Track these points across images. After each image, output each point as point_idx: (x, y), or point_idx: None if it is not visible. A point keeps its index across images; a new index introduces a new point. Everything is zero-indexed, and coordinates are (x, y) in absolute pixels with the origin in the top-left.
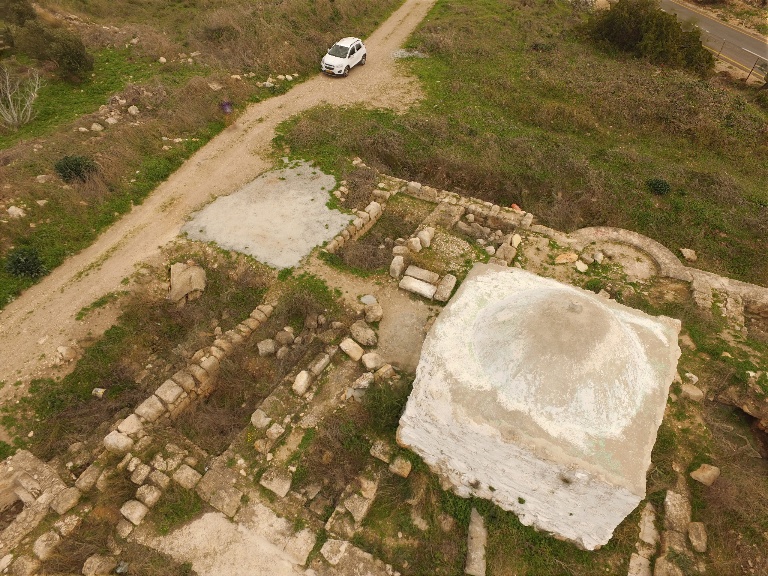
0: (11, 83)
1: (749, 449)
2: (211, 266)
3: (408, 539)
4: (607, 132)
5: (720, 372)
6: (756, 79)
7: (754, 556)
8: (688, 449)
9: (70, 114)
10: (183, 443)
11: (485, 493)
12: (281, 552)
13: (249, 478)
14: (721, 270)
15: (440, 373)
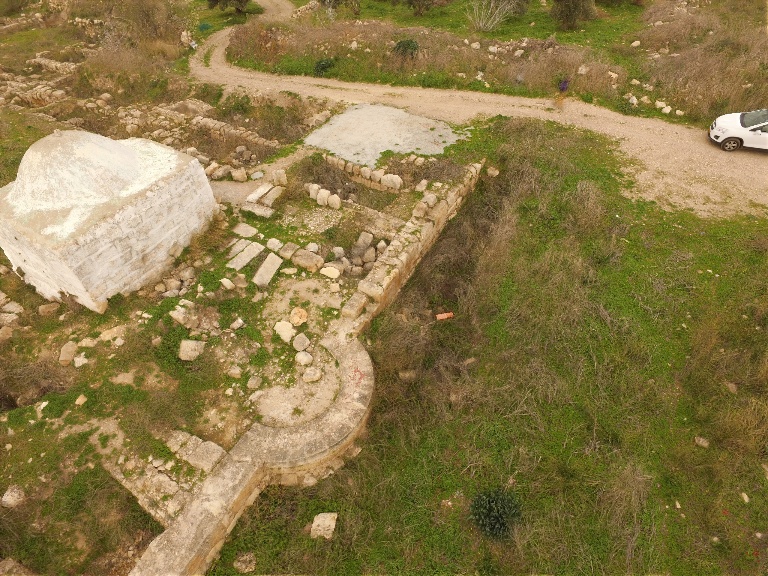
0: None
1: None
2: None
3: None
4: None
5: None
6: None
7: None
8: None
9: (506, 39)
10: (191, 140)
11: None
12: None
13: None
14: None
15: None
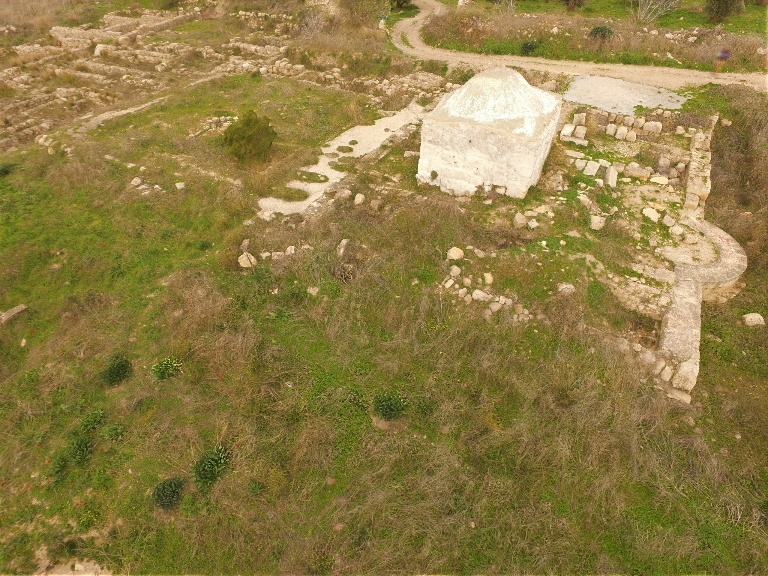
0: (667, 0)
1: None
2: None
3: None
4: None
5: None
6: None
7: None
8: None
9: None
10: None
11: None
12: None
13: None
14: (743, 344)
15: None
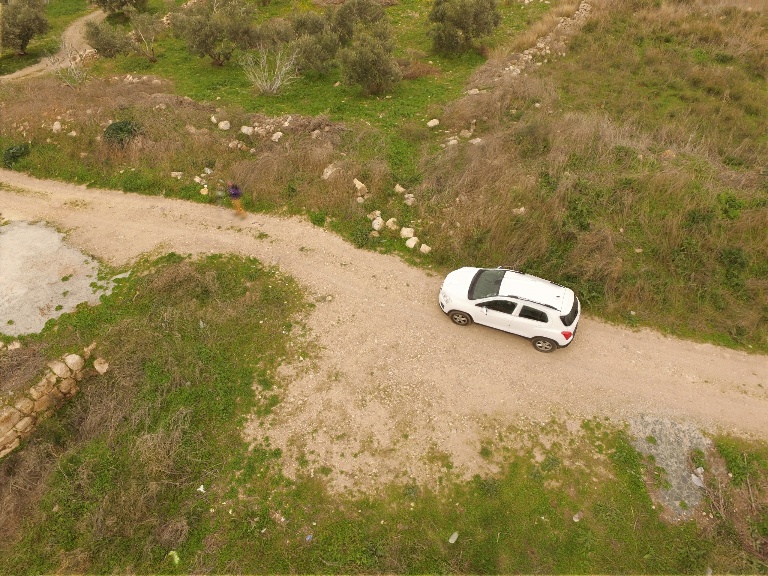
0: None
1: None
2: None
3: None
4: None
5: None
6: None
7: None
8: None
9: (285, 109)
10: None
11: None
12: None
13: None
14: None
15: None
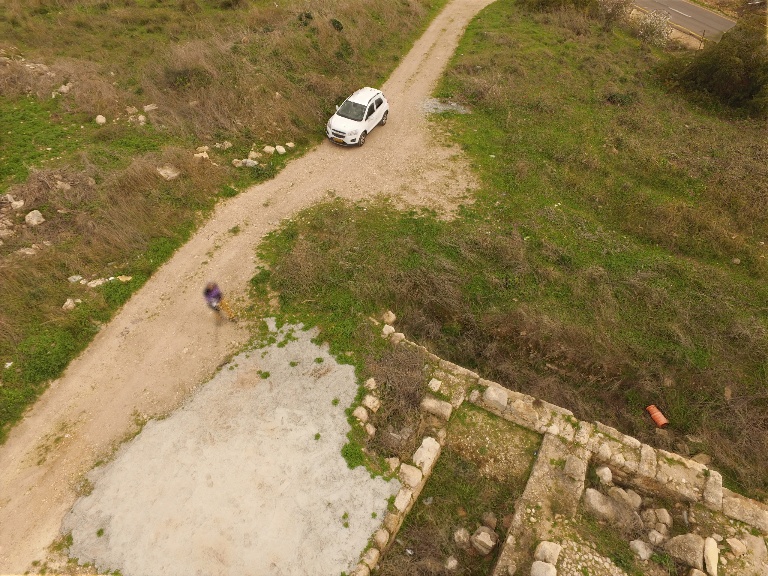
0: None
1: None
2: None
3: None
4: (764, 257)
5: None
6: None
7: None
8: None
9: None
10: None
11: None
12: None
13: None
14: None
15: None
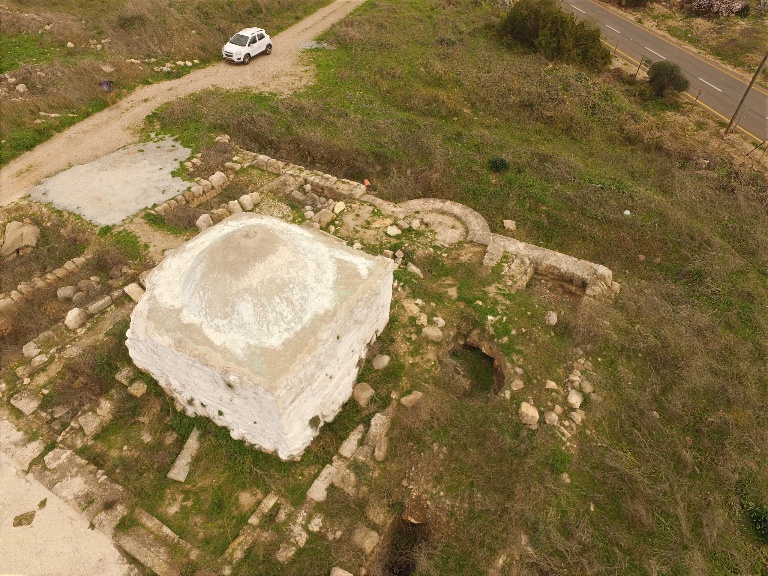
0: None
1: (458, 378)
2: (45, 225)
3: (131, 451)
4: None
5: (467, 317)
6: (646, 75)
7: (418, 462)
8: (410, 380)
9: None
10: None
11: (200, 410)
12: (10, 460)
13: (3, 399)
14: (535, 239)
15: (147, 296)
